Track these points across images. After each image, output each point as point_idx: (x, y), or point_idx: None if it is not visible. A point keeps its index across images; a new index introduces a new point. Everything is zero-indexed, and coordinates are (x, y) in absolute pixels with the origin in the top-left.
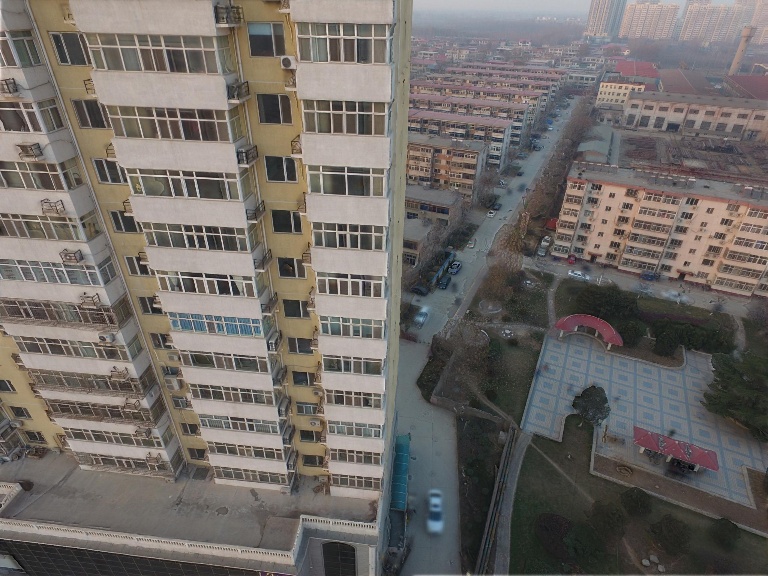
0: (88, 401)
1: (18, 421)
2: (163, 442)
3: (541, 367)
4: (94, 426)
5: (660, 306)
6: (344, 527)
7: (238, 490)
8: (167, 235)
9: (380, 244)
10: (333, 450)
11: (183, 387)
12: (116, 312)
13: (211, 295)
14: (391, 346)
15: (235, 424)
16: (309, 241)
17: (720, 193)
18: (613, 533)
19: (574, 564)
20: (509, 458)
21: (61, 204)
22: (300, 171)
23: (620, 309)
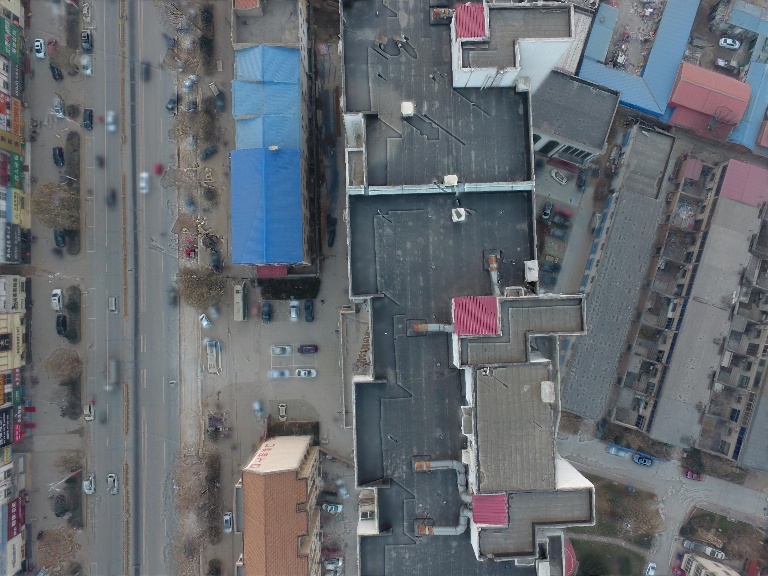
0: None
1: None
2: None
3: None
4: None
5: None
6: None
7: None
8: None
9: None
10: None
11: None
12: None
13: None
14: None
15: None
16: None
17: None
18: None
19: None
20: None
21: None
22: None
23: None
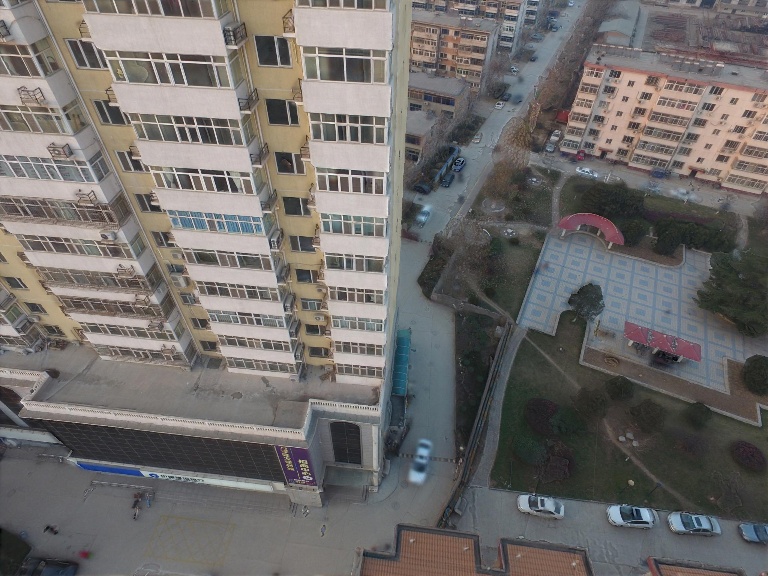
0: (99, 297)
1: (35, 316)
2: (176, 335)
3: (541, 266)
4: (108, 321)
5: (666, 205)
6: (349, 409)
7: (250, 378)
8: (157, 127)
9: (382, 137)
10: (337, 342)
11: (190, 284)
12: (114, 210)
13: (209, 192)
14: (393, 244)
15: (243, 319)
16: (307, 134)
17: (748, 81)
18: (595, 415)
19: (557, 440)
20: (504, 350)
21: (40, 92)
22: (294, 53)
23: (625, 208)
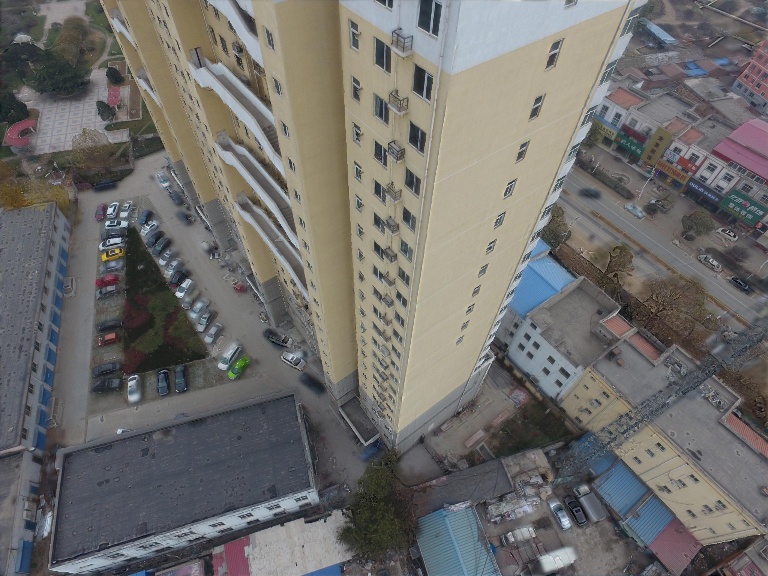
0: None
1: None
2: None
3: None
4: None
5: None
6: None
7: None
8: None
9: None
10: None
11: None
12: None
13: None
14: None
15: None
16: None
17: None
18: None
19: None
20: None
21: None
22: None
23: None
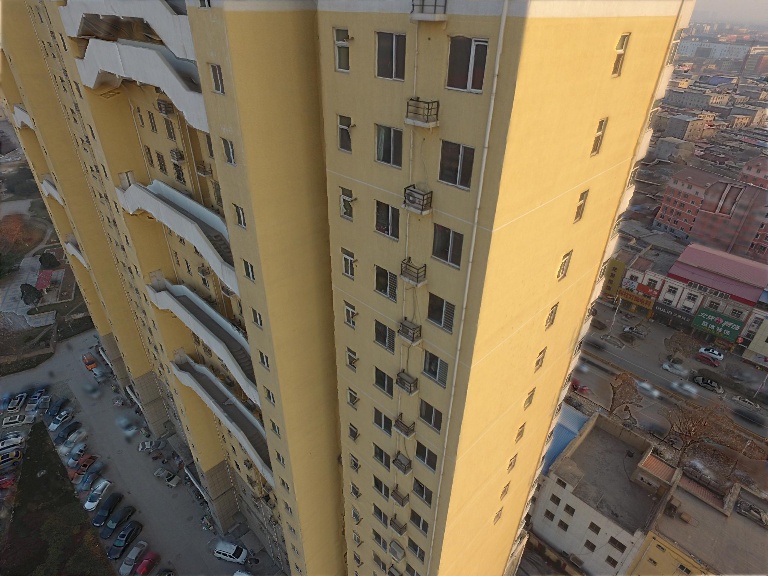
0: None
1: None
2: None
3: None
4: None
5: None
6: None
7: None
8: None
9: None
10: None
11: None
12: None
13: None
14: None
15: None
16: None
17: None
18: None
19: None
20: None
21: None
22: None
23: None
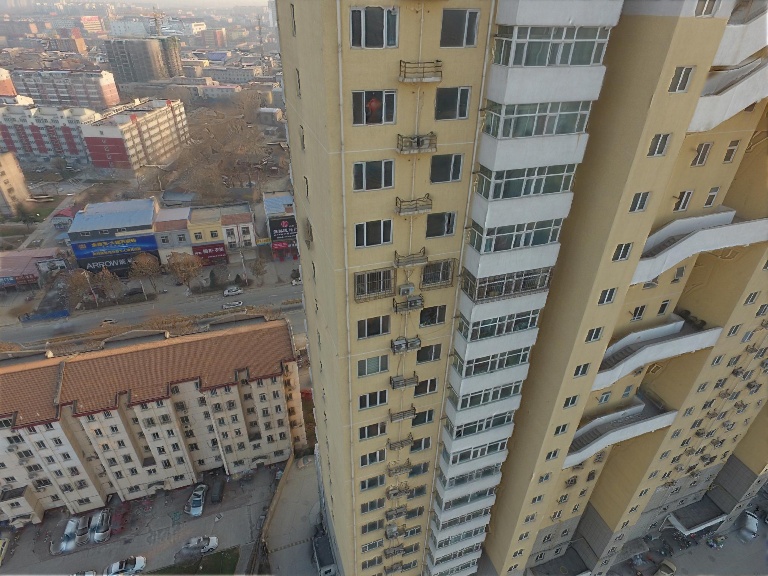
0: None
1: None
2: None
3: None
4: None
5: None
6: None
7: None
8: None
9: None
10: None
11: None
12: None
13: None
14: None
15: None
16: None
17: None
18: None
19: None
20: None
21: None
22: None
23: None
